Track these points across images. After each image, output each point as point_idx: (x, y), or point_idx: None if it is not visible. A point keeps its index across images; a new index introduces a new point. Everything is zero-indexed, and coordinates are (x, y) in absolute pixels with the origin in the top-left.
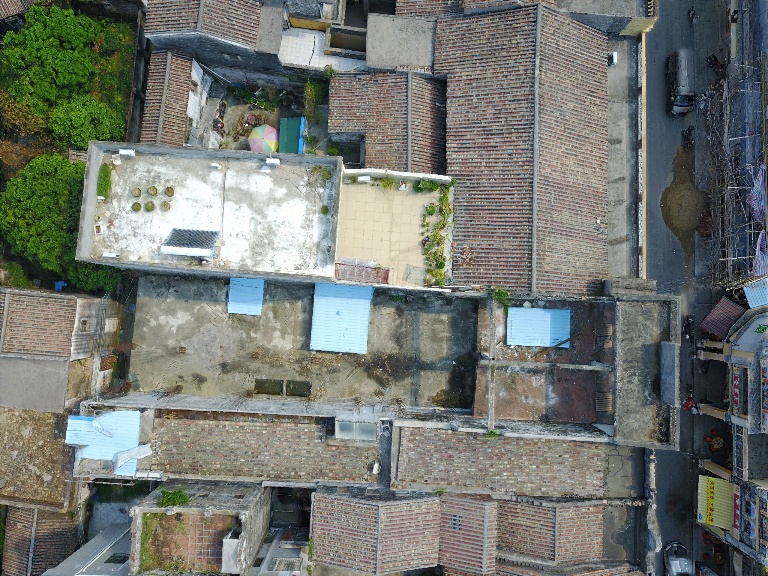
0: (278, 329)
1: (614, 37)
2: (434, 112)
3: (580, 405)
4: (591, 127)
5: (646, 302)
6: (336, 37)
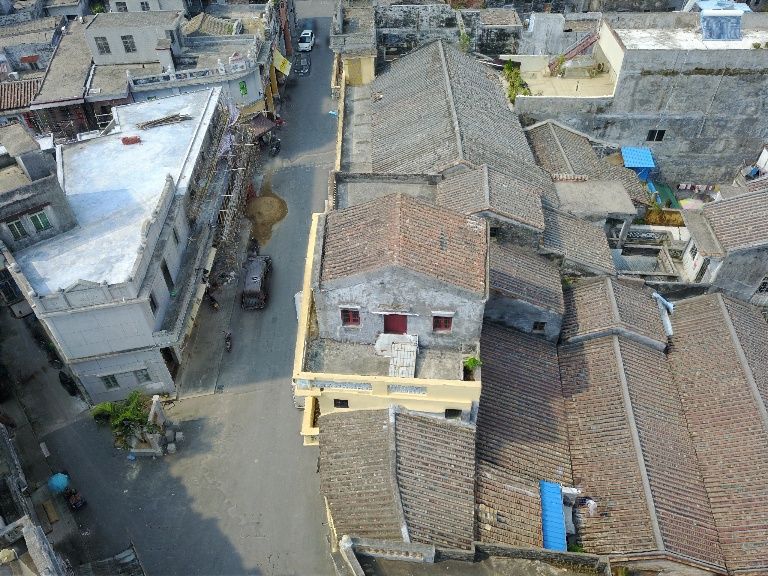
0: None
1: None
2: None
3: None
4: None
5: None
6: None
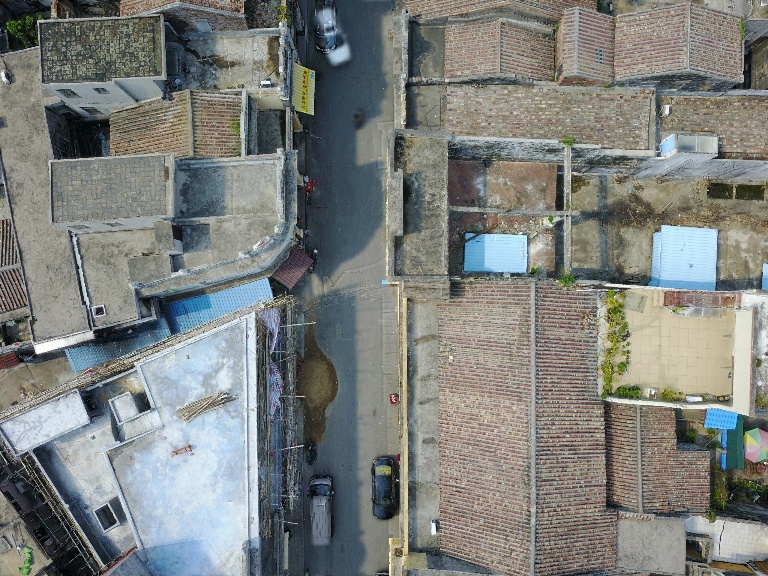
0: (743, 250)
1: (431, 551)
2: (609, 472)
3: (452, 177)
4: (460, 455)
5: (418, 275)
6: (693, 554)
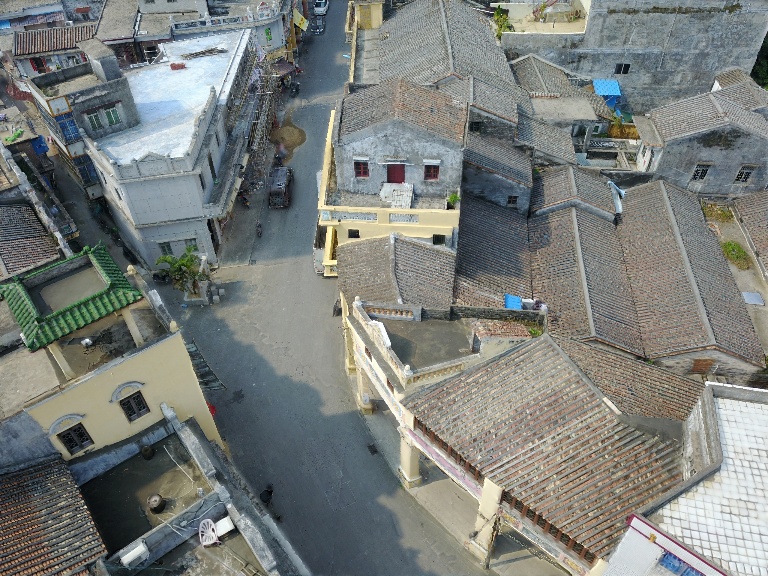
0: None
1: None
2: None
3: None
4: None
5: None
6: None
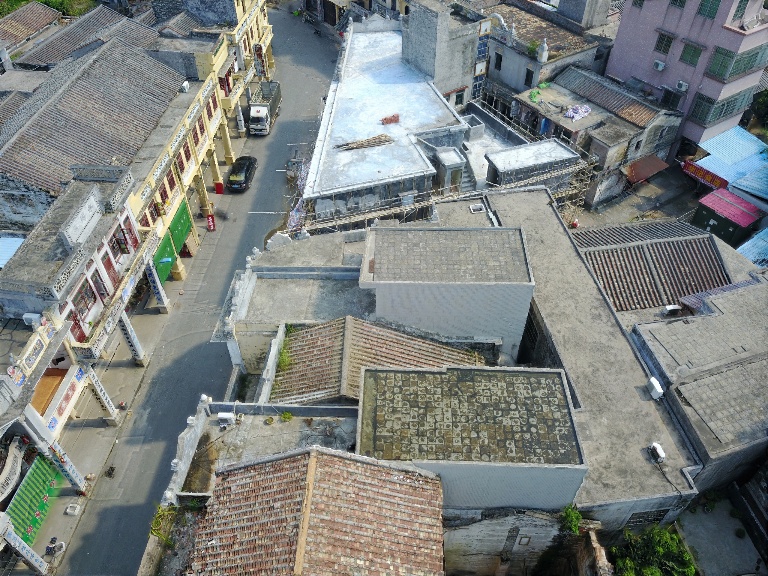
0: None
1: (194, 81)
2: None
3: None
4: None
5: (104, 183)
6: None
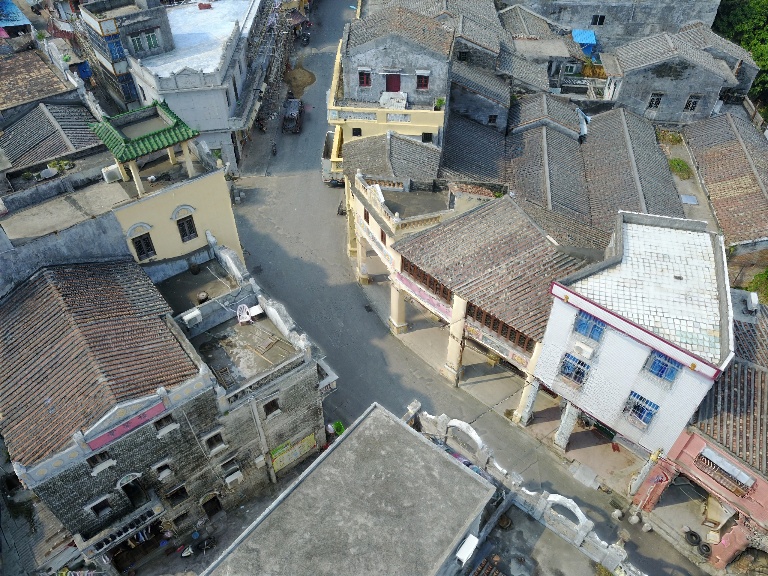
0: None
1: None
2: None
3: None
4: None
5: None
6: None
